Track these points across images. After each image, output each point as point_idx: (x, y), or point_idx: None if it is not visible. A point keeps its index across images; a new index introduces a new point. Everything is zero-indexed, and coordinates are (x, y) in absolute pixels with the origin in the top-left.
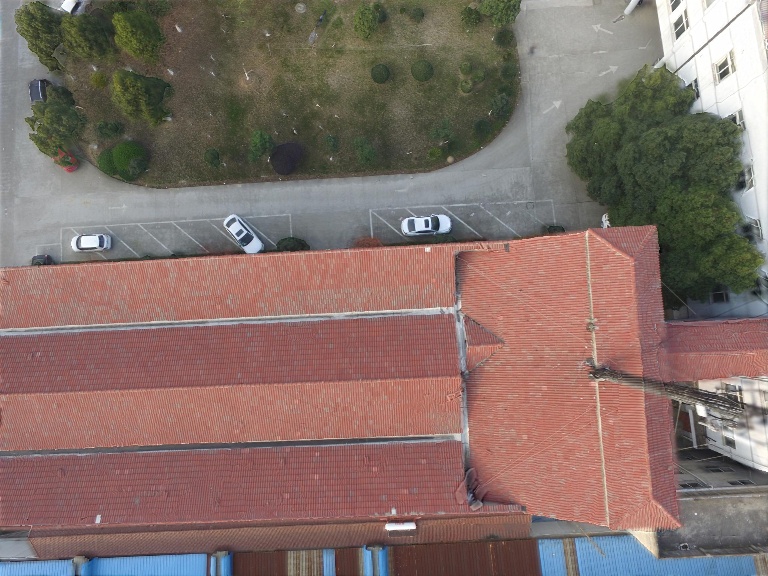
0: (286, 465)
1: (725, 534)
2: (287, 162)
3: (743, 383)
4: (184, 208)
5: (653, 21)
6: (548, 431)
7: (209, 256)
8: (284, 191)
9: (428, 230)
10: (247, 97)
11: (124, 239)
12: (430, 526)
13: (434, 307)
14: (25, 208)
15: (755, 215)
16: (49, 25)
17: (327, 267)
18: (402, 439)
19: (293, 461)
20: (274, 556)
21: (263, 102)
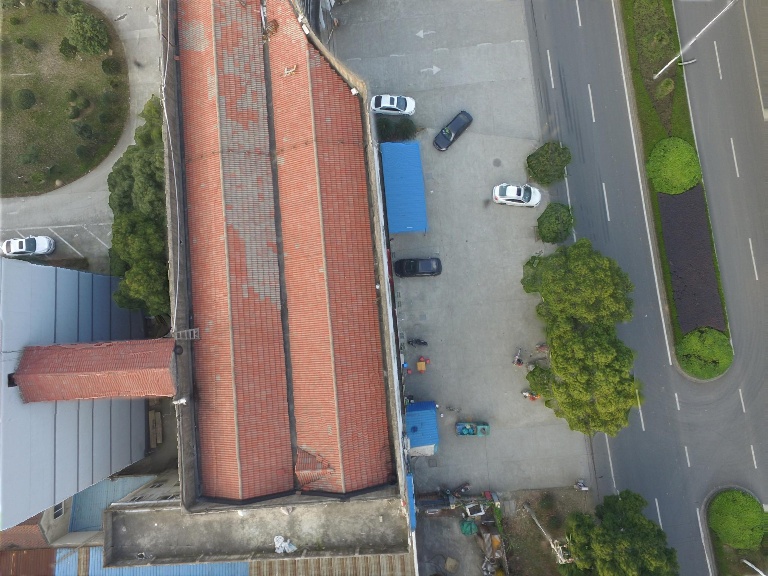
0: None
1: (181, 544)
2: None
3: None
4: None
5: None
6: None
7: None
8: None
9: (22, 251)
10: None
11: None
12: None
13: None
14: None
15: None
16: None
17: None
18: None
19: None
20: None
21: None
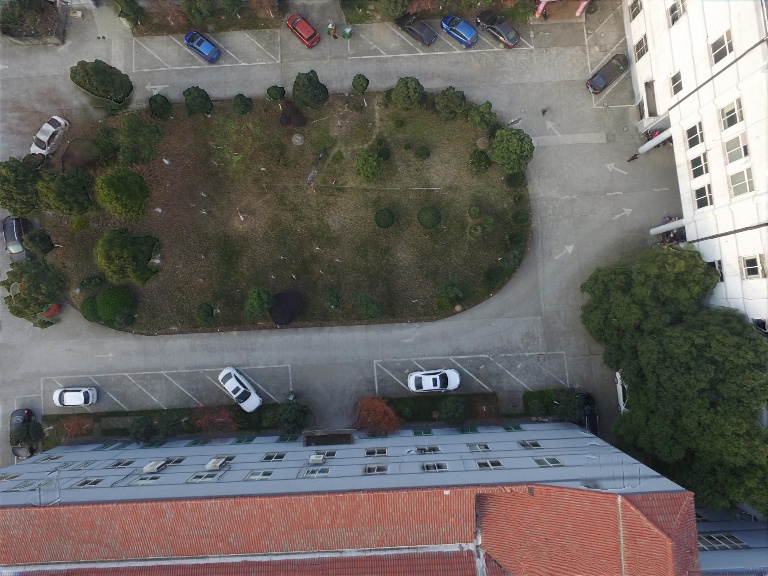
0: None
1: None
2: (286, 314)
3: None
4: (175, 357)
5: (671, 174)
6: None
7: (209, 499)
8: (283, 340)
9: (436, 389)
10: (242, 238)
11: (111, 391)
12: None
13: (452, 543)
14: (1, 355)
15: None
16: (24, 185)
17: (338, 508)
18: None
19: None
20: None
21: (259, 243)
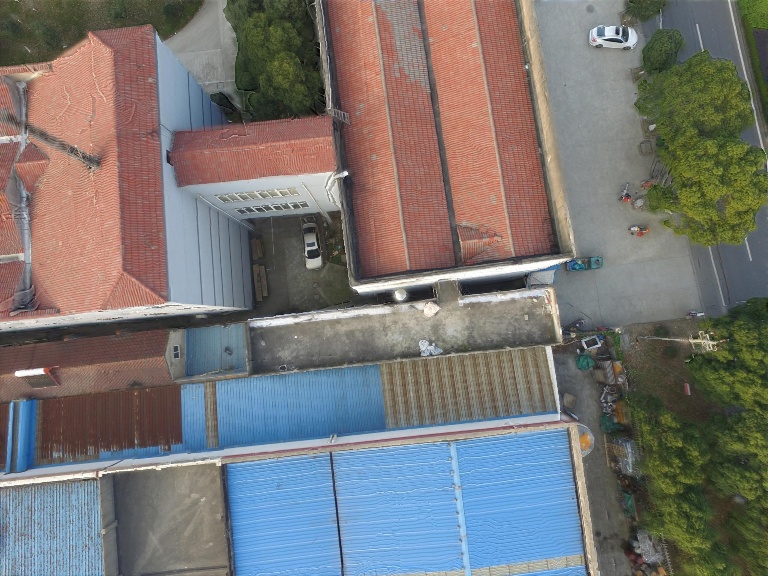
0: None
1: (323, 354)
2: None
3: None
4: None
5: None
6: None
7: None
8: None
9: None
10: None
11: None
12: (69, 375)
13: (2, 136)
14: None
15: None
16: None
17: None
18: None
19: None
20: None
21: None
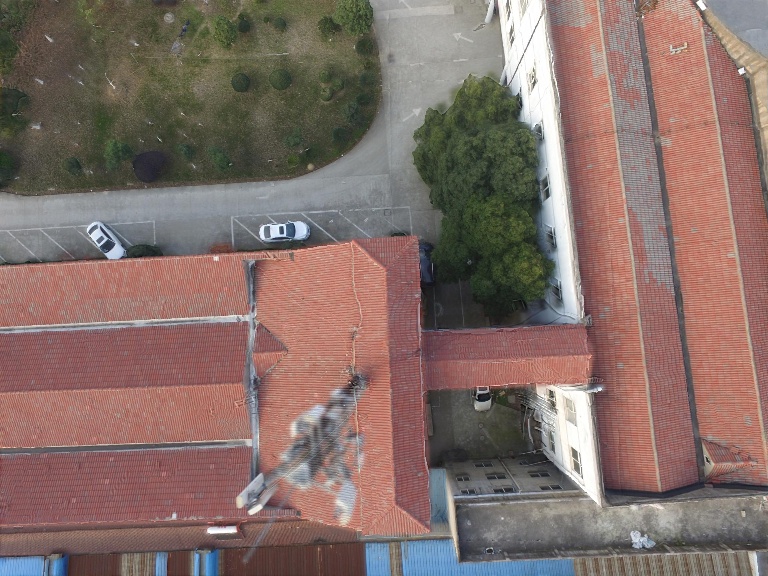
0: (80, 470)
1: (530, 538)
2: (148, 170)
3: (555, 389)
4: (52, 215)
5: (500, 30)
6: (318, 437)
7: (6, 265)
8: (149, 198)
9: (283, 237)
10: (114, 106)
11: None
12: (256, 529)
13: (230, 315)
14: None
15: (552, 224)
16: None
17: (121, 276)
18: (196, 444)
19: (87, 466)
20: (109, 558)
21: (130, 111)
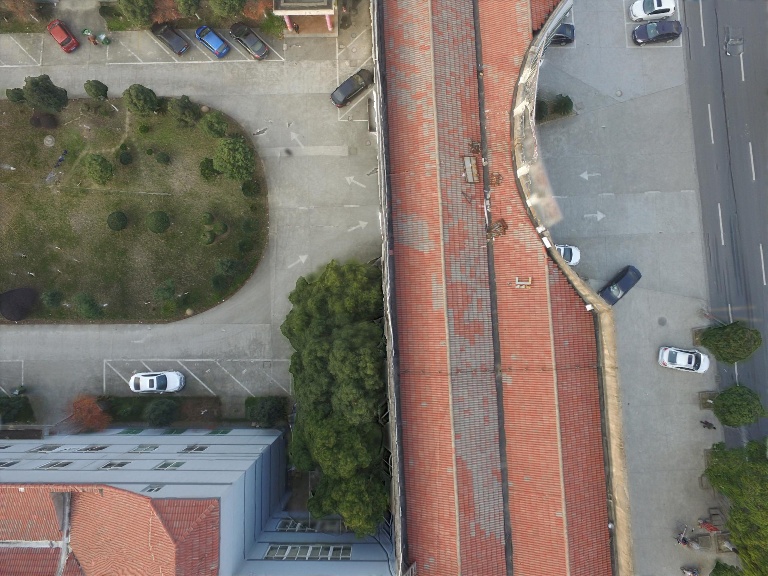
0: None
1: None
2: (14, 310)
3: None
4: None
5: None
6: None
7: None
8: (18, 335)
9: (153, 390)
10: None
11: None
12: None
13: (42, 540)
14: None
15: None
16: None
17: None
18: None
19: None
20: None
21: (2, 240)
